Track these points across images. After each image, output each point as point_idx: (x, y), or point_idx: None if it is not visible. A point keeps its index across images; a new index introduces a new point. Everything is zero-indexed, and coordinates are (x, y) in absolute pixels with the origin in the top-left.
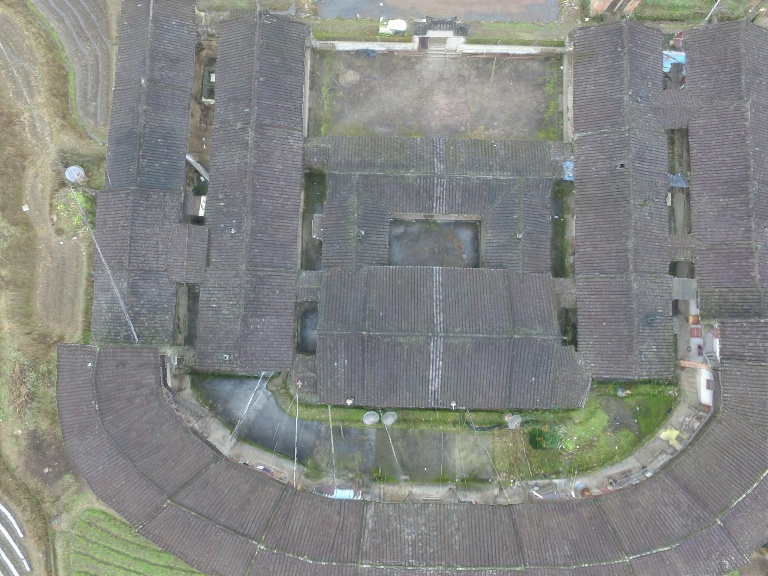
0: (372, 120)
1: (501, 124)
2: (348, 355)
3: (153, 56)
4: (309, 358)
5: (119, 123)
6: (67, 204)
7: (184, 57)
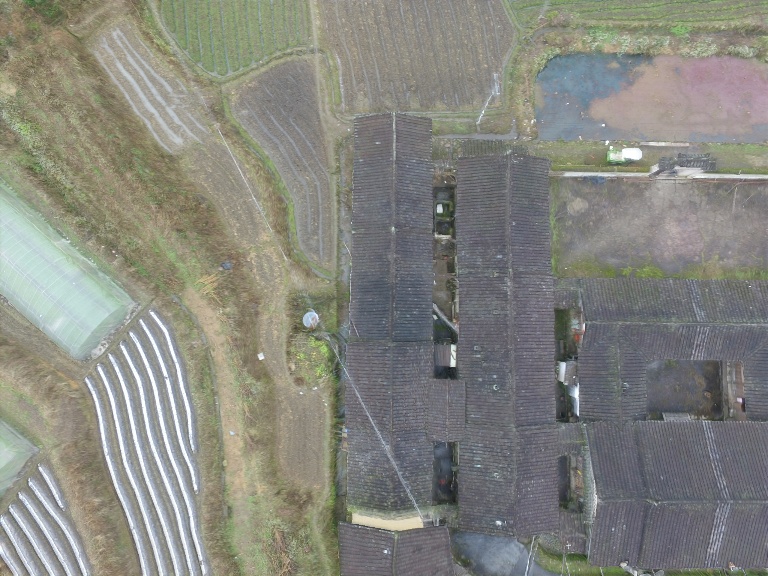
0: (604, 251)
1: (735, 253)
2: (628, 520)
3: (398, 199)
4: (574, 516)
5: (364, 270)
6: (307, 353)
7: (425, 196)
